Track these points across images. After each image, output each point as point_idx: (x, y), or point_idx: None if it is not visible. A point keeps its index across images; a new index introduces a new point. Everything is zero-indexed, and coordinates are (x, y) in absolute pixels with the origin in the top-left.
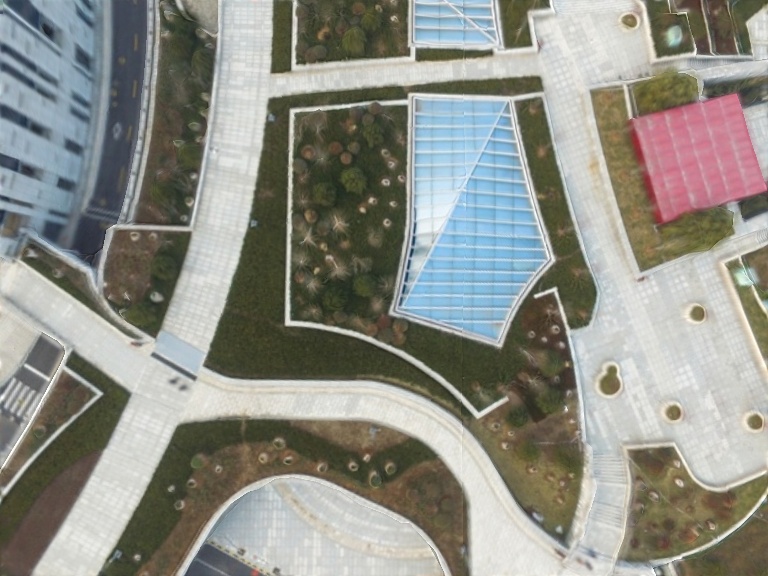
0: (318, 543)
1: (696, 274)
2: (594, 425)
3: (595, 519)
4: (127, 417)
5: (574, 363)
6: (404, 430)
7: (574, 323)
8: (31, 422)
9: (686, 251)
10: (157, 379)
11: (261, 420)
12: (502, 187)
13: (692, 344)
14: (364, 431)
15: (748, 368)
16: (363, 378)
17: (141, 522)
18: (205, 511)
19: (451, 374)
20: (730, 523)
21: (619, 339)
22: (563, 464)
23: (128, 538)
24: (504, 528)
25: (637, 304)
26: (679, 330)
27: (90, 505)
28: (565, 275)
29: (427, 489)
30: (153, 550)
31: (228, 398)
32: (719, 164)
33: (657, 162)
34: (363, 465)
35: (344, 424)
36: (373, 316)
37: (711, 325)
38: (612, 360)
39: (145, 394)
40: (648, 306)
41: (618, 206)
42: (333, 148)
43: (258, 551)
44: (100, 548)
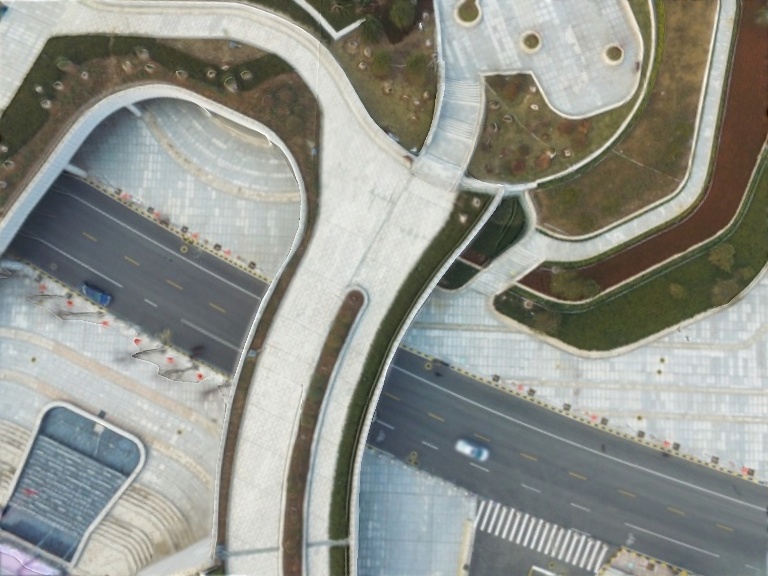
0: (191, 186)
1: None
2: (452, 54)
3: (445, 130)
4: (3, 29)
5: None
6: (264, 48)
7: None
8: None
9: None
10: None
11: (129, 37)
12: None
13: None
14: (225, 48)
15: (610, 5)
16: (227, 1)
17: (10, 119)
18: (71, 114)
19: None
20: (587, 152)
21: None
22: (413, 71)
23: None
24: (356, 137)
25: None
26: None
27: None
28: None
29: (281, 95)
30: (20, 145)
31: (99, 17)
32: None
33: None
34: (221, 72)
35: (207, 42)
36: None
37: None
38: None
39: (21, 9)
40: None
41: None
42: None
43: (134, 191)
44: None
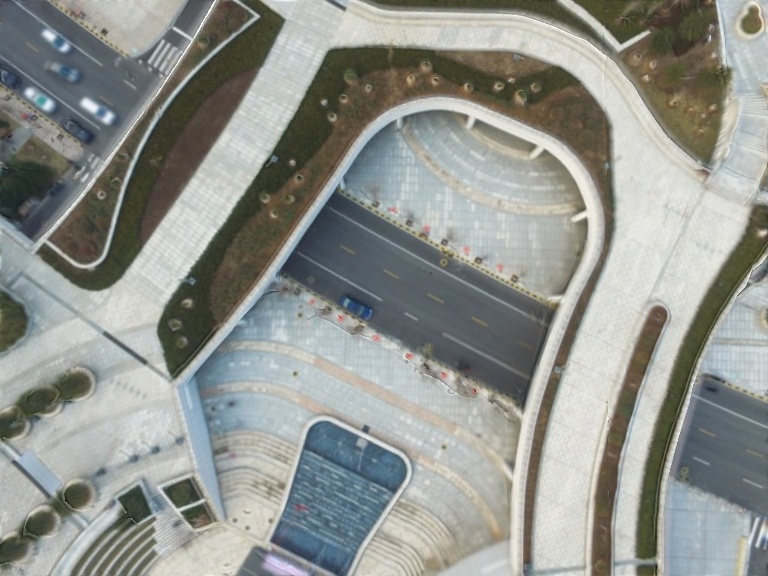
0: (450, 198)
1: None
2: (734, 66)
3: (738, 144)
4: (281, 41)
5: None
6: (546, 60)
7: None
8: (194, 39)
9: None
10: (309, 8)
11: (407, 49)
12: None
13: None
14: (507, 60)
15: None
16: (506, 13)
17: (295, 132)
18: (355, 127)
19: (594, 7)
20: None
21: None
22: (708, 84)
23: (283, 146)
24: (646, 150)
25: None
26: None
27: (247, 117)
28: None
29: (571, 108)
30: (306, 159)
31: (376, 29)
32: None
33: None
34: (508, 85)
35: (488, 54)
36: None
37: None
38: (754, 1)
39: (298, 21)
40: None
41: None
42: None
43: (392, 204)
44: (257, 156)
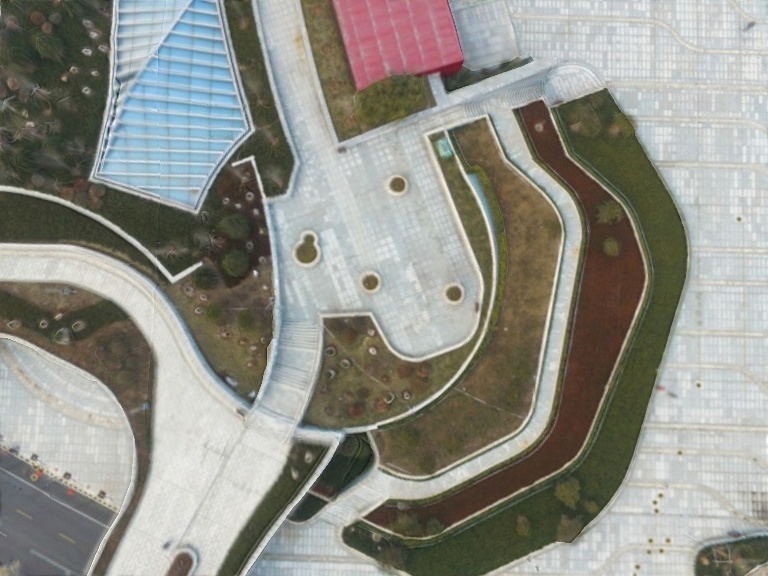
0: (41, 412)
1: (401, 147)
2: (292, 294)
3: (279, 381)
4: None
5: (269, 231)
6: (100, 292)
7: (270, 191)
8: None
9: (379, 119)
10: None
11: None
12: (201, 57)
13: (395, 216)
14: (61, 293)
15: (452, 241)
16: (64, 243)
17: None
18: None
19: (146, 239)
20: (427, 394)
21: (320, 210)
22: None
23: None
24: (189, 388)
25: (339, 176)
26: (381, 202)
27: None
28: (262, 144)
29: (113, 347)
30: None
31: None
32: (416, 34)
33: (353, 32)
34: (53, 323)
35: (43, 286)
36: (70, 181)
37: (414, 198)
38: (310, 229)
39: None
40: (351, 178)
41: (319, 77)
42: (35, 18)
43: None
44: None
